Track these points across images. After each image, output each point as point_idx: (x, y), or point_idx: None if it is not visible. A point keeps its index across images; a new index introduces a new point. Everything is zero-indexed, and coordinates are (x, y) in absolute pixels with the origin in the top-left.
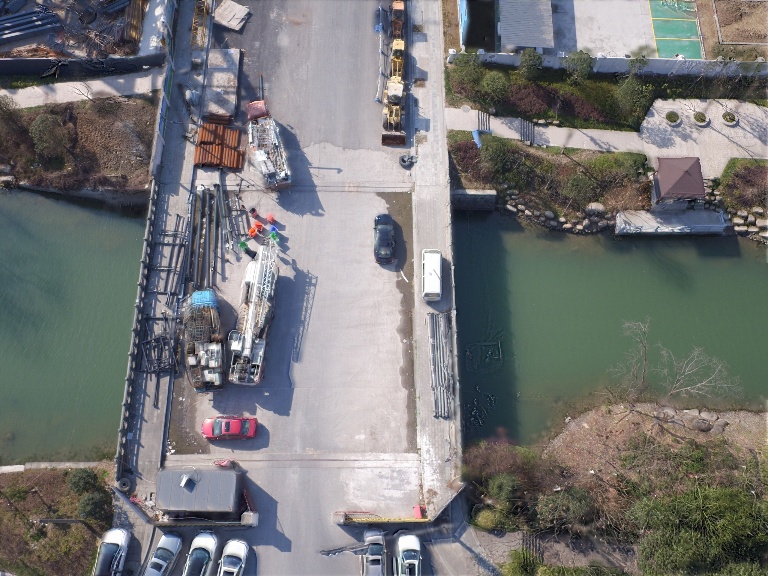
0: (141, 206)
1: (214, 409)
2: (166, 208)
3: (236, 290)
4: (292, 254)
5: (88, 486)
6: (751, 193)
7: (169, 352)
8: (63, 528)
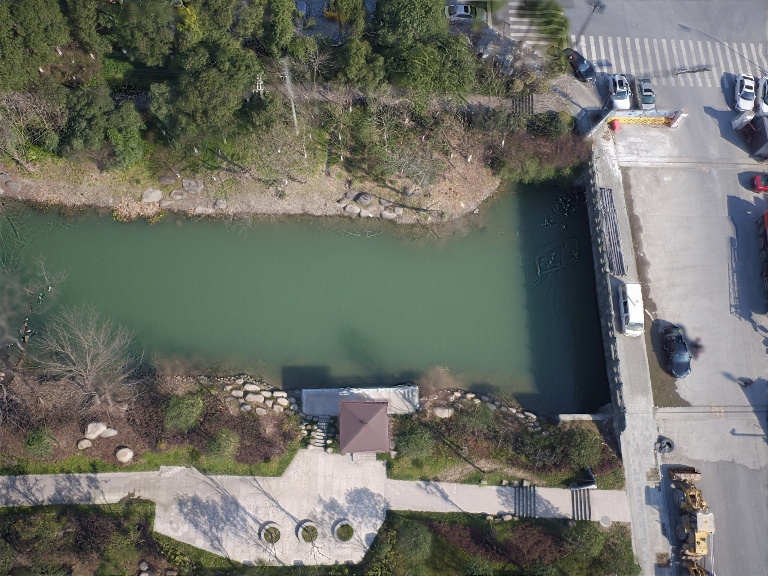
0: None
1: None
2: None
3: None
4: (759, 337)
5: None
6: (268, 428)
7: None
8: None
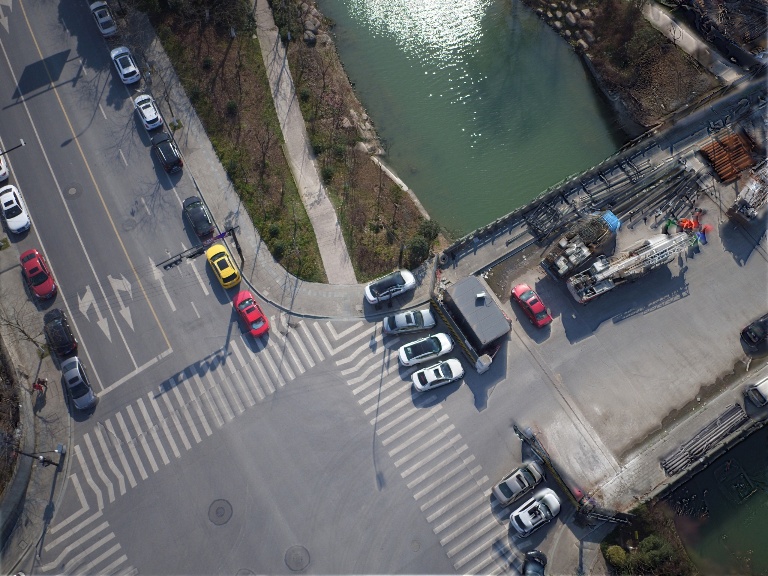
0: (632, 132)
1: (535, 285)
2: (646, 149)
3: (630, 240)
4: (690, 263)
5: (428, 235)
6: None
7: (550, 225)
8: (389, 240)
